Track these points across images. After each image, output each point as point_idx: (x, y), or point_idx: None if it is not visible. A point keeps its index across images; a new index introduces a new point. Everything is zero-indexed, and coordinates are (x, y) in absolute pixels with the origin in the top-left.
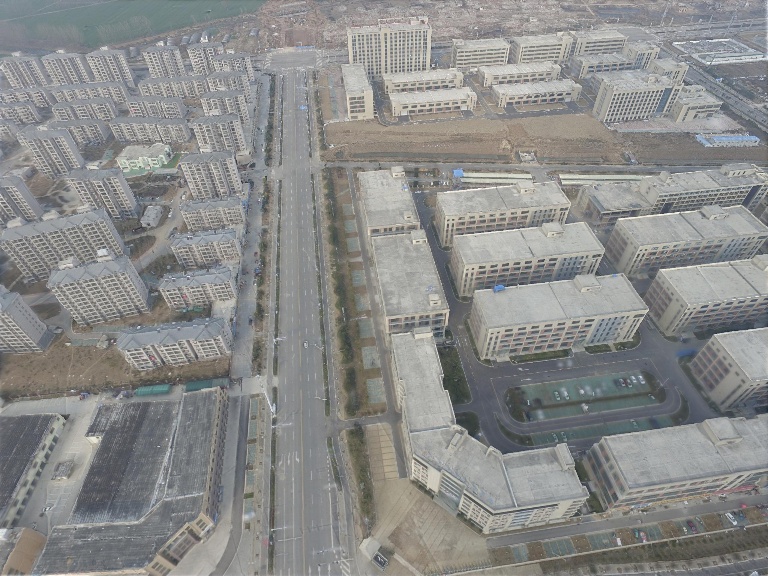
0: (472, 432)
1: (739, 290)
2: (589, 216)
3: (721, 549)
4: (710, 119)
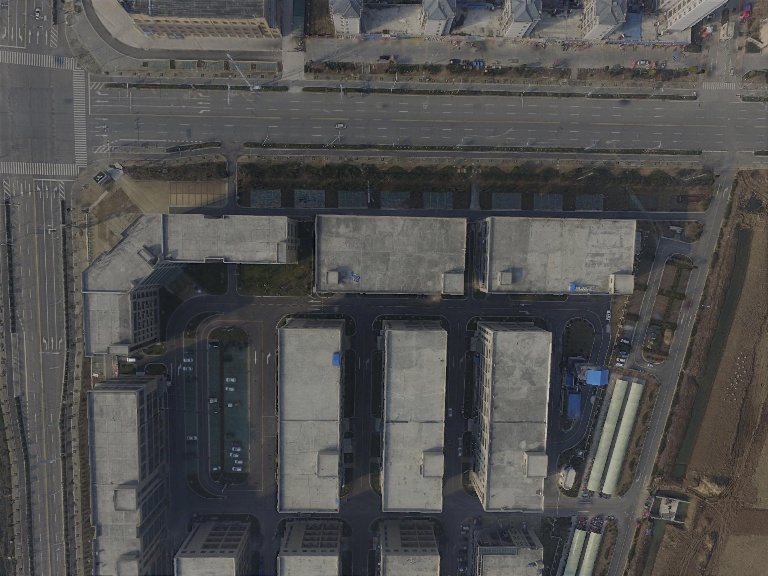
0: (204, 285)
1: None
2: (495, 533)
3: (83, 450)
4: None
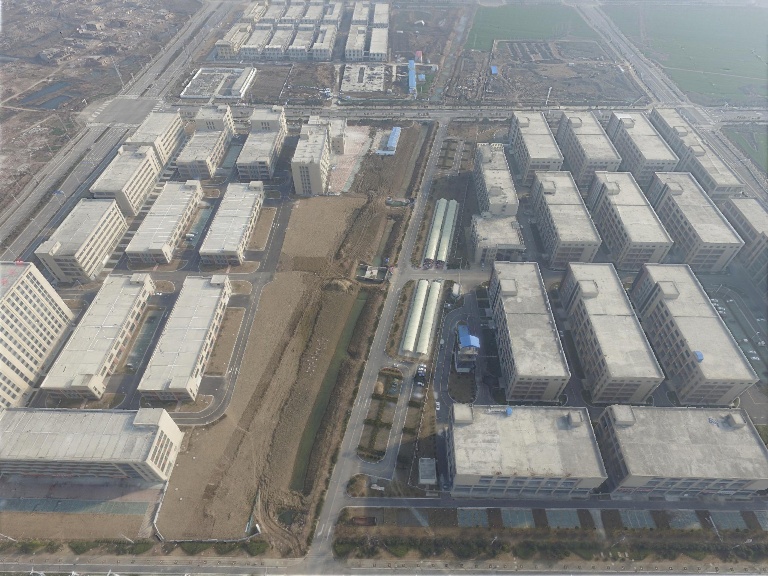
0: None
1: (645, 213)
2: (505, 260)
3: None
4: (347, 135)
